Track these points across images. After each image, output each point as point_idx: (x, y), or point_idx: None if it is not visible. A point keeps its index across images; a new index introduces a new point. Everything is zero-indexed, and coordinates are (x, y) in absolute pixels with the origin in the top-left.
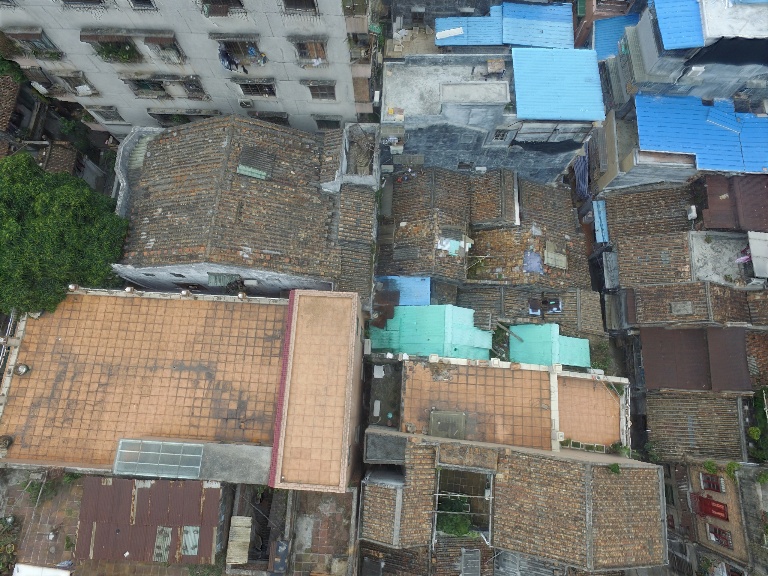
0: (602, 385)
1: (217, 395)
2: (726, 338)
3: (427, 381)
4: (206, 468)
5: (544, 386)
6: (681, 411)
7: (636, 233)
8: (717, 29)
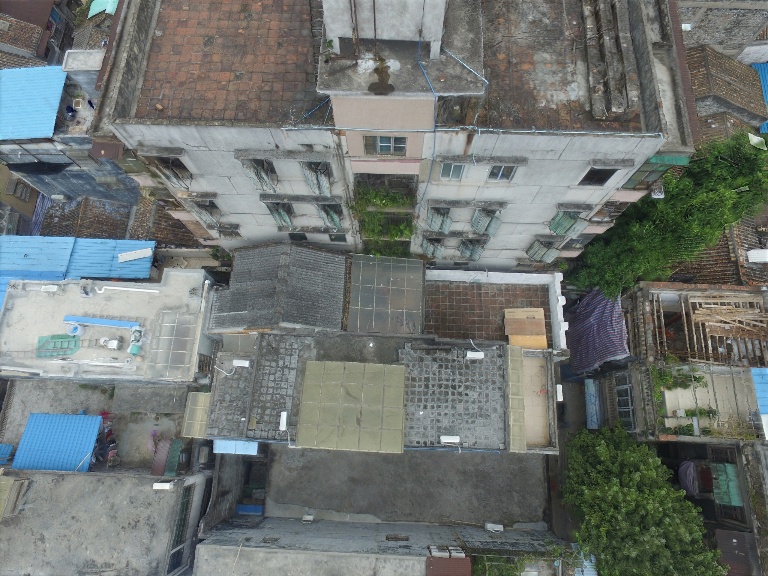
0: None
1: None
2: None
3: None
4: None
5: None
6: None
7: None
8: None
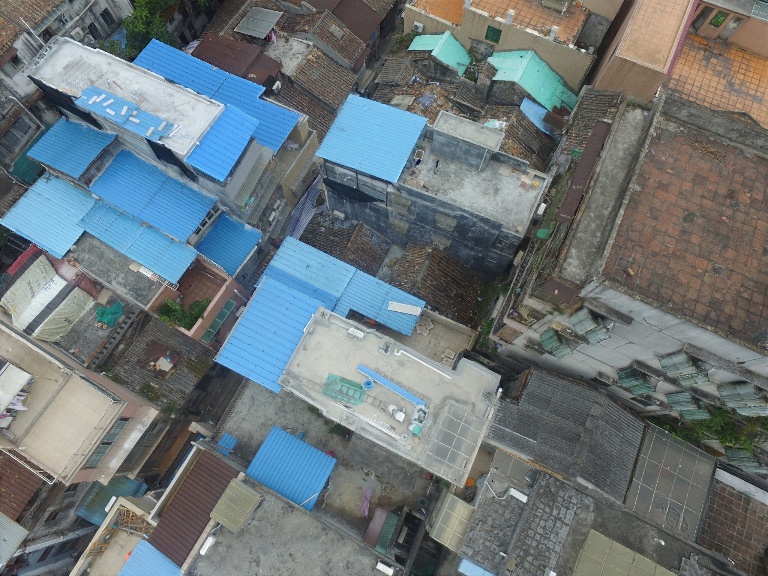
0: (425, 8)
1: (726, 71)
2: (322, 5)
3: (560, 30)
4: (750, 3)
5: (478, 1)
6: (368, 0)
7: (317, 109)
8: (207, 111)
